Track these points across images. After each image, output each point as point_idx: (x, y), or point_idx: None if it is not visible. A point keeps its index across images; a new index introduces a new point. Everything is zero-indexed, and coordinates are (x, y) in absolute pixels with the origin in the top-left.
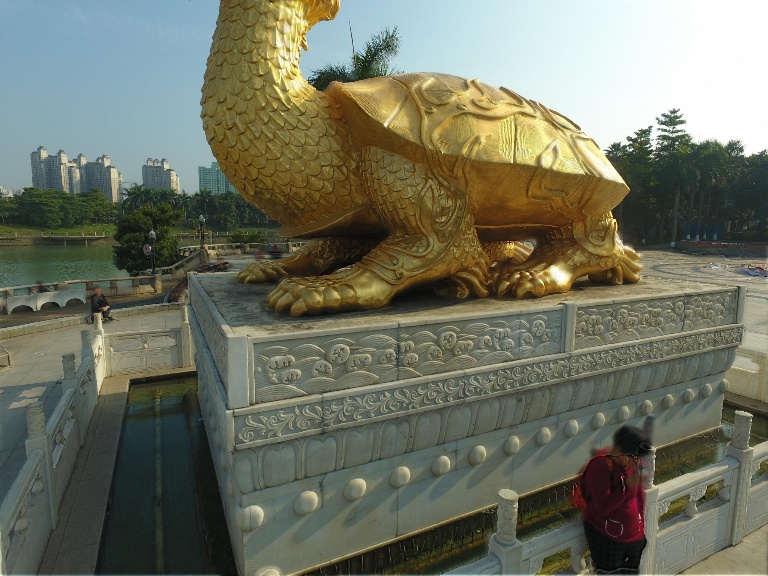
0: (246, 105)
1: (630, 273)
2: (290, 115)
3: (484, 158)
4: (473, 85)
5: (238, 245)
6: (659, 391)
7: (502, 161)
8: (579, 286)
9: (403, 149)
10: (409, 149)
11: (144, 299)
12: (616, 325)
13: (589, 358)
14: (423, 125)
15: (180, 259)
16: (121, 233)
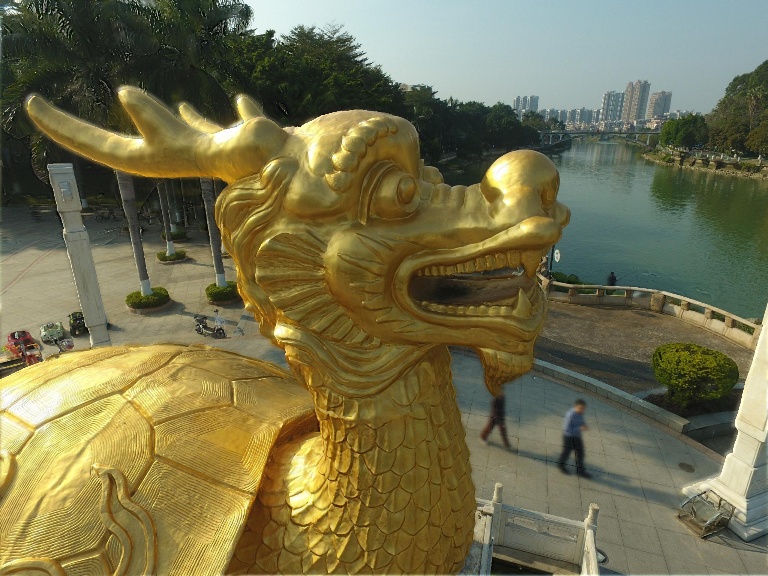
0: None
1: None
2: None
3: None
4: None
5: None
6: None
7: None
8: None
9: None
10: None
11: None
12: None
13: None
14: None
15: None
16: None
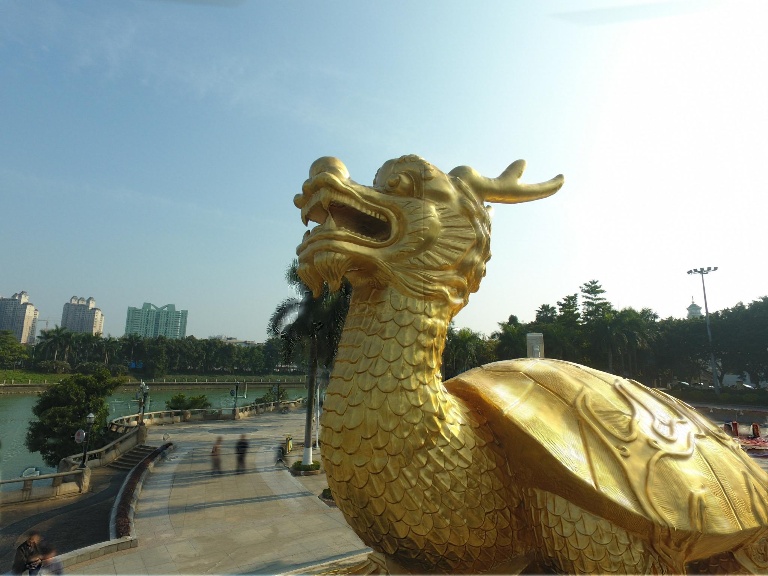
0: (402, 444)
1: None
2: (450, 450)
3: (716, 529)
4: (626, 393)
5: (178, 412)
6: None
7: (733, 530)
8: None
9: (617, 517)
10: (627, 519)
11: (66, 505)
12: None
13: None
14: (633, 481)
15: (111, 436)
16: (43, 406)
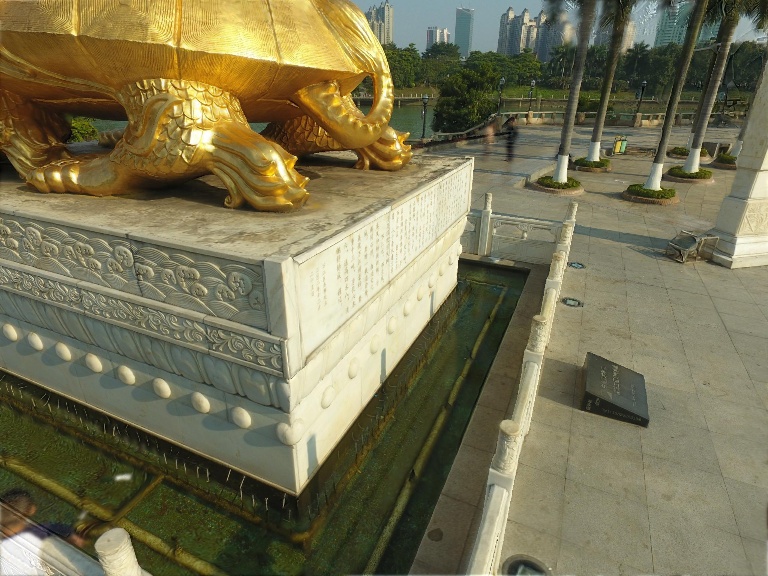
0: None
1: (244, 192)
2: None
3: None
4: None
5: None
6: (143, 366)
7: None
8: (182, 196)
9: None
10: None
11: None
12: (30, 245)
13: (4, 271)
14: None
15: None
16: (442, 96)
